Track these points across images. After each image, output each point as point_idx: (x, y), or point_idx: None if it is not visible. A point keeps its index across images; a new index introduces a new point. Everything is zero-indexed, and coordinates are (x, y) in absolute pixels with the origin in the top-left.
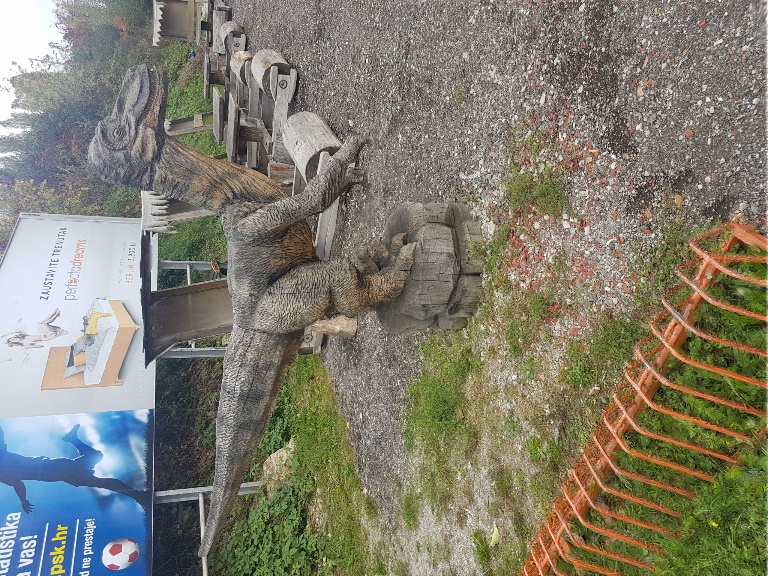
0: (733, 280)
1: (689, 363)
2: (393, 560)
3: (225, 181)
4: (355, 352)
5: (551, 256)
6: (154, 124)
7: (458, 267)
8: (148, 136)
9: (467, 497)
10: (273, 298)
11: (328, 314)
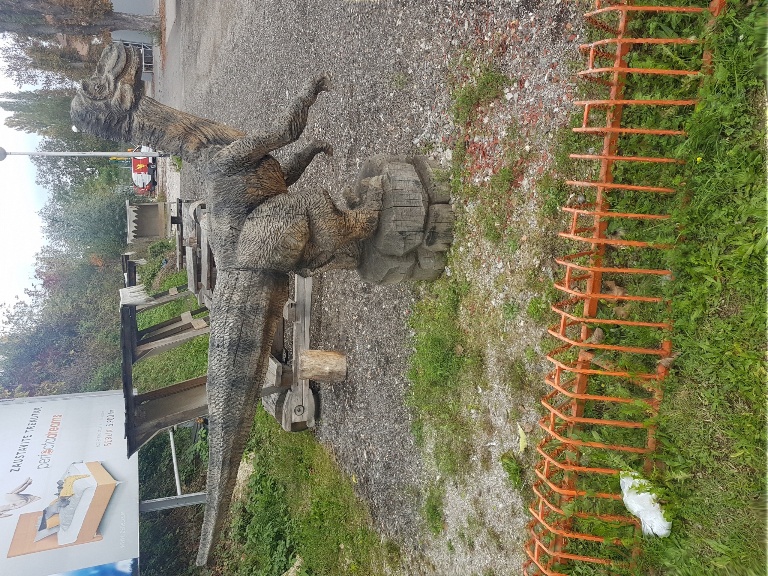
0: None
1: (621, 8)
2: None
3: (198, 128)
4: (349, 394)
5: (504, 130)
6: (131, 82)
7: (426, 194)
8: (126, 90)
9: (485, 428)
10: (253, 222)
11: (310, 267)
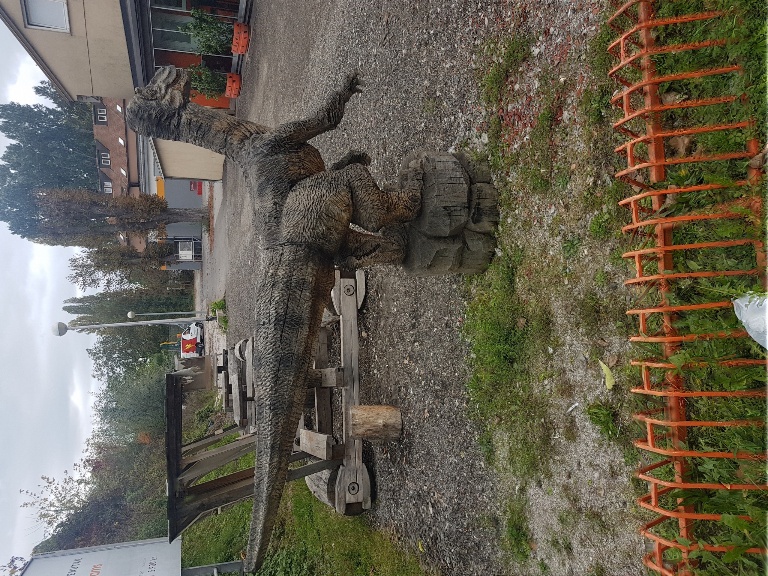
0: None
1: None
2: None
3: (242, 124)
4: (406, 449)
5: None
6: (180, 90)
7: (467, 174)
8: (175, 94)
9: (564, 391)
10: (296, 192)
11: (356, 255)
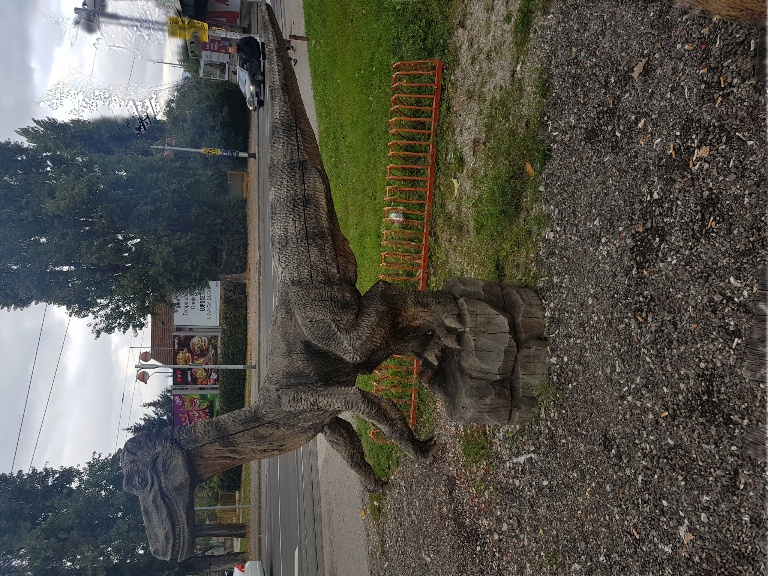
0: None
1: None
2: None
3: None
4: None
5: None
6: None
7: None
8: None
9: None
10: None
11: None
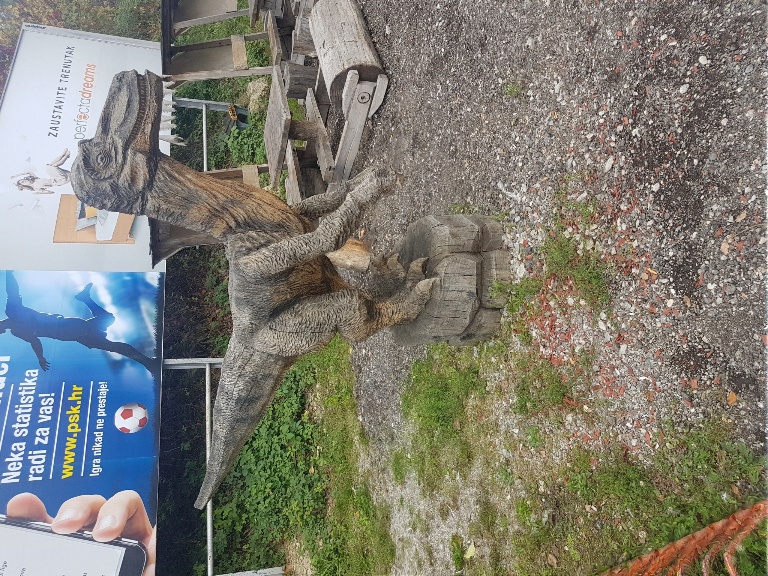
0: (762, 546)
1: None
2: (378, 493)
3: (227, 210)
4: None
5: (578, 347)
6: (145, 147)
7: (478, 304)
8: (138, 163)
9: (452, 499)
10: (274, 334)
11: None
